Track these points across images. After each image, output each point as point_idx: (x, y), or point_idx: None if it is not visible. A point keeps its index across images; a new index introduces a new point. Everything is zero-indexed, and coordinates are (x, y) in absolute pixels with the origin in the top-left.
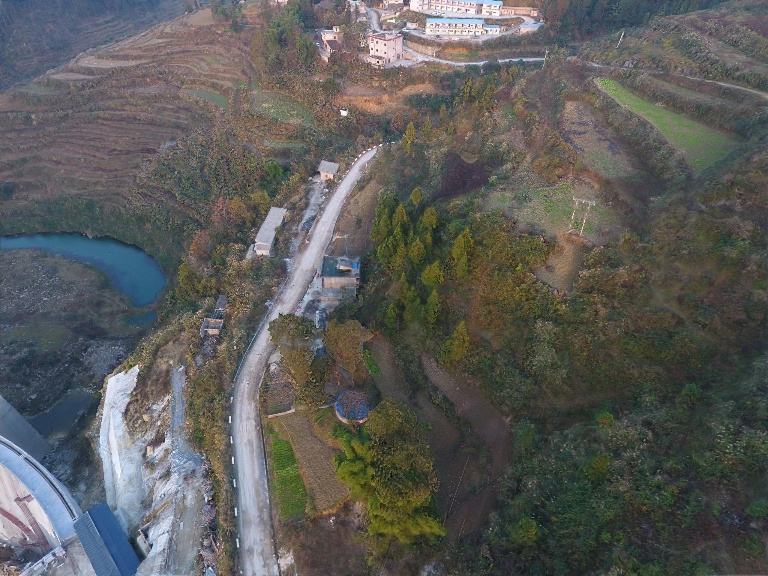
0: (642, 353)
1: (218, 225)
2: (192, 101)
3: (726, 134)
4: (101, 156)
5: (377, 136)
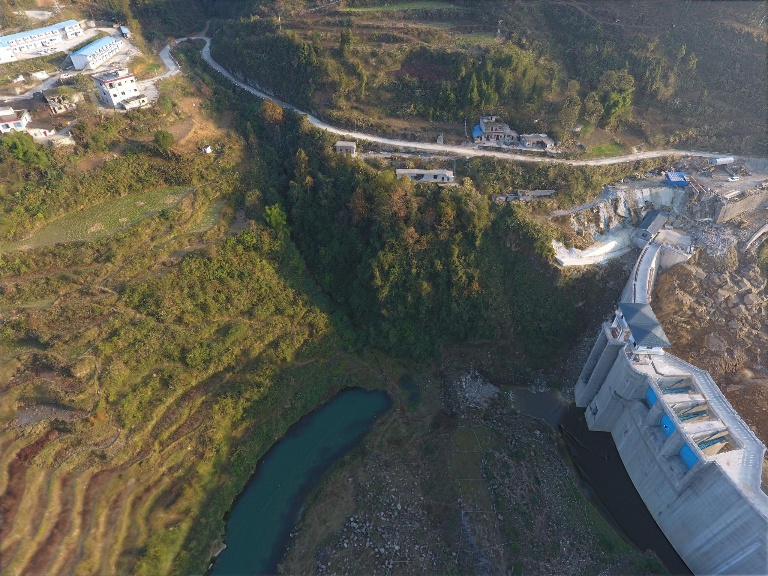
0: None
1: (416, 205)
2: None
3: None
4: None
5: None
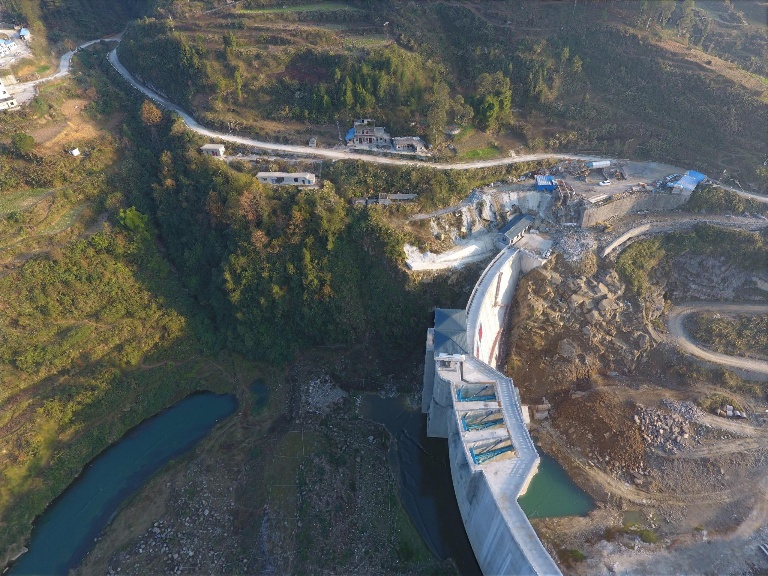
0: (444, 49)
1: None
2: None
3: None
4: None
5: (181, 119)
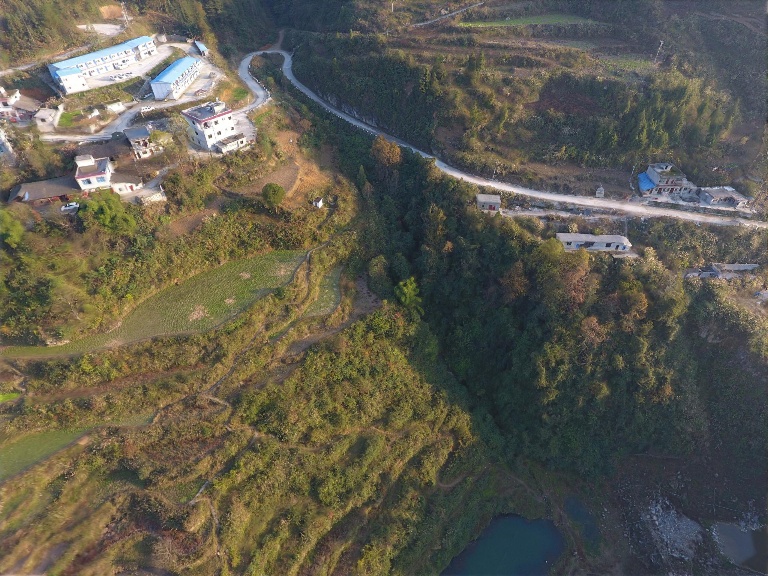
0: None
1: None
2: None
3: (547, 14)
4: None
5: None
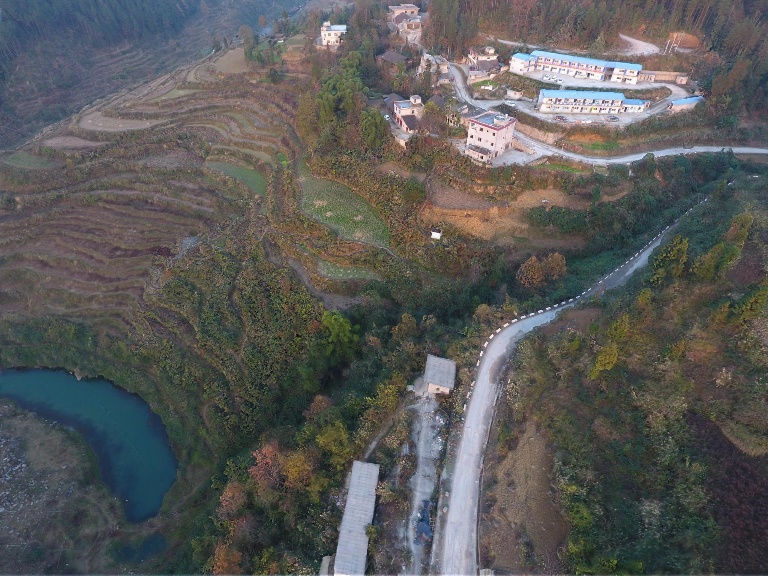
0: None
1: (263, 495)
2: (219, 180)
3: None
4: (99, 257)
5: (510, 308)
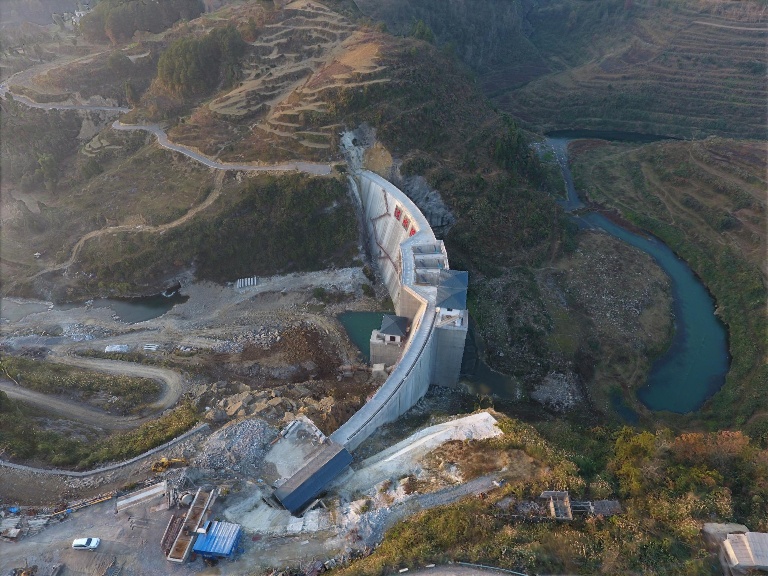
0: None
1: (761, 459)
2: None
3: None
4: None
5: None
